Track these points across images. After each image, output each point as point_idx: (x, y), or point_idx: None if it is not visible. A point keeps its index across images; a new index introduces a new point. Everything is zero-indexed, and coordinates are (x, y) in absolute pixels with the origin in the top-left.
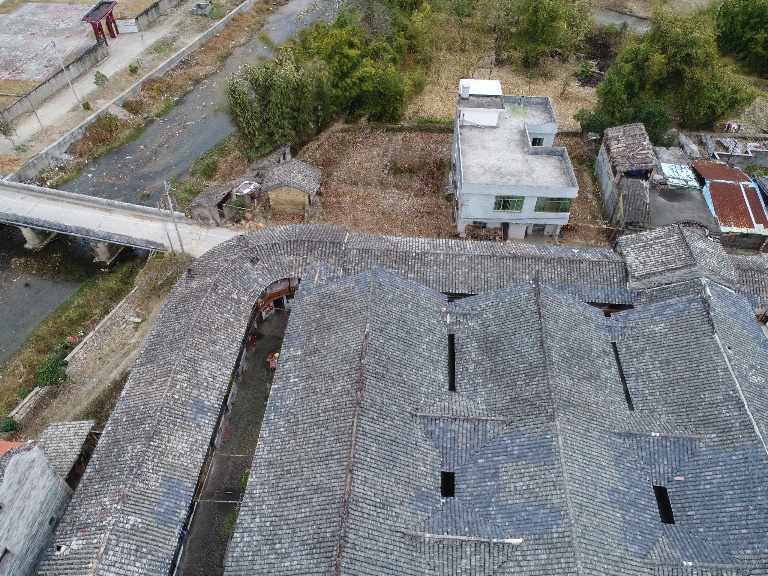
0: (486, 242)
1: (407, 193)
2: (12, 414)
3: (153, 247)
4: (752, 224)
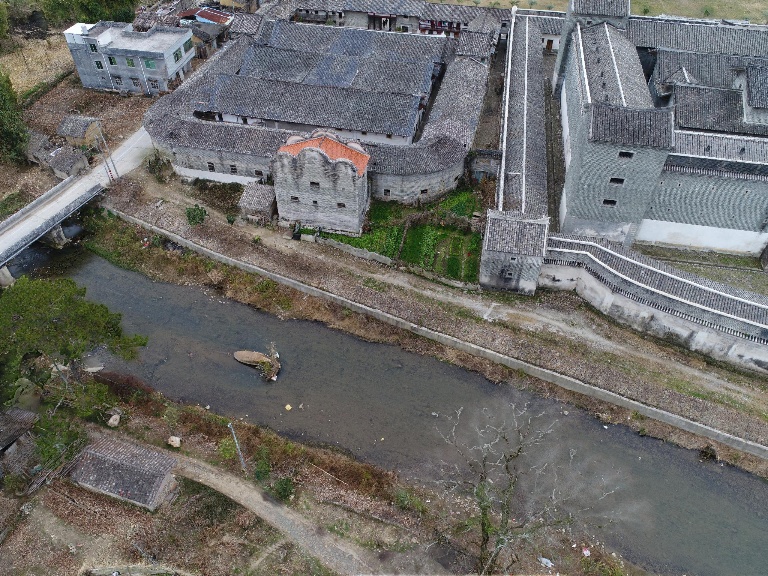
0: (201, 66)
1: (108, 109)
2: (206, 249)
3: (95, 192)
4: (228, 18)
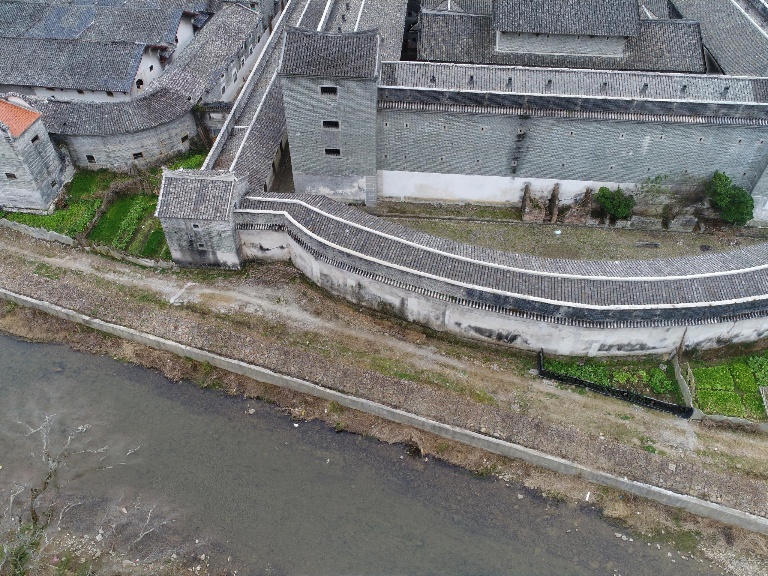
0: None
1: None
2: None
3: None
4: None
